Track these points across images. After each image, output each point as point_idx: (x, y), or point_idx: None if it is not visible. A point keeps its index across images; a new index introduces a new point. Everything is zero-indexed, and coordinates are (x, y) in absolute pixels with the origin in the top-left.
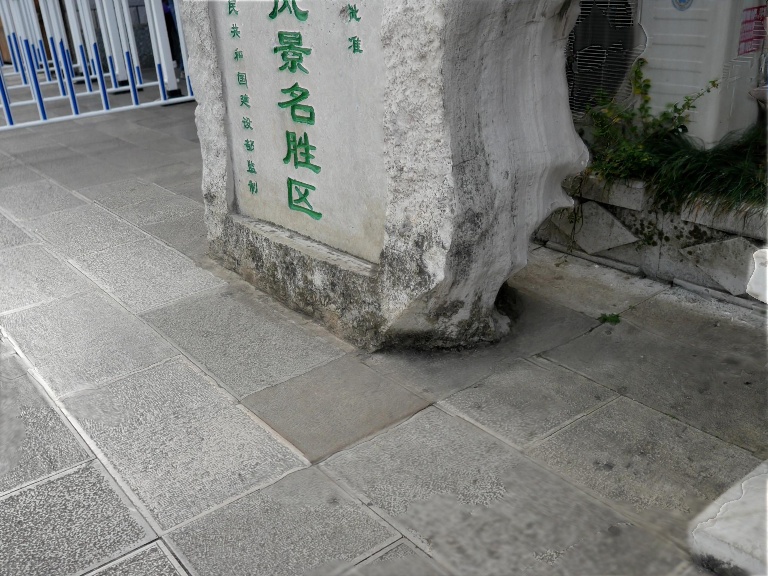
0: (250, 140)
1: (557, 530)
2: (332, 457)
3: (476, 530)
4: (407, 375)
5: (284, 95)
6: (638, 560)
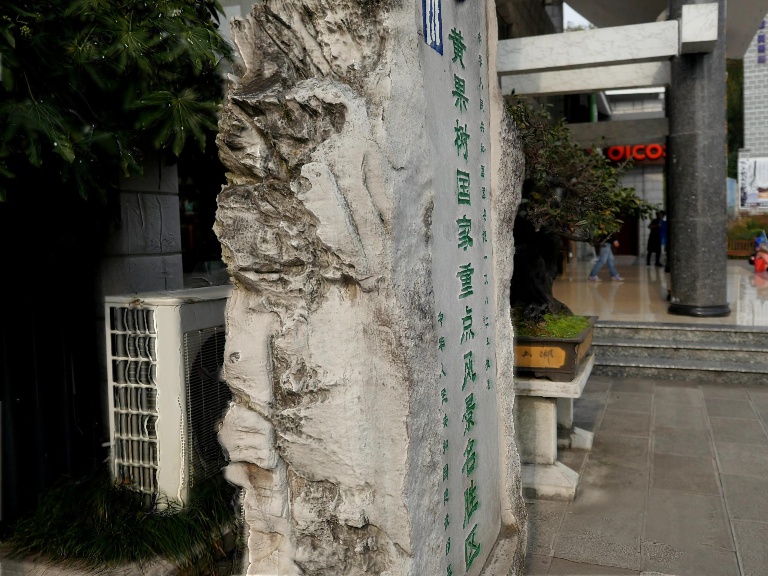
0: (448, 539)
1: (592, 520)
2: (629, 568)
3: (616, 531)
4: (536, 571)
5: (465, 458)
6: (584, 509)
